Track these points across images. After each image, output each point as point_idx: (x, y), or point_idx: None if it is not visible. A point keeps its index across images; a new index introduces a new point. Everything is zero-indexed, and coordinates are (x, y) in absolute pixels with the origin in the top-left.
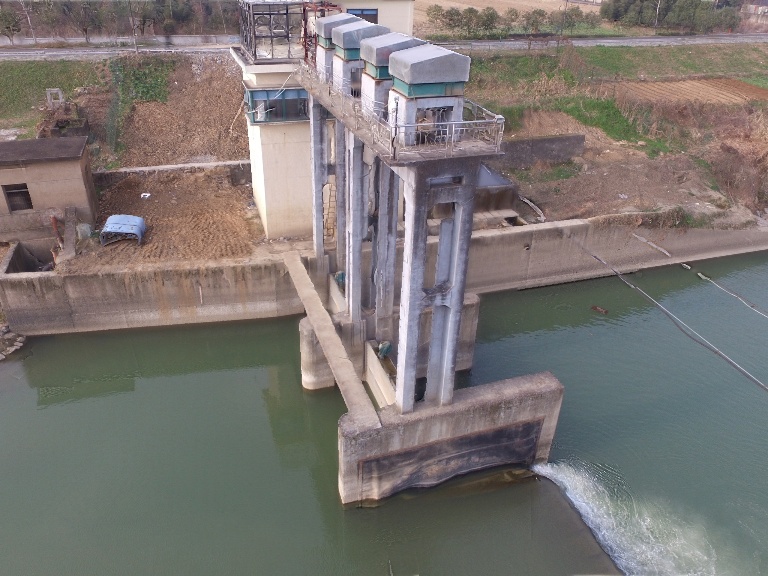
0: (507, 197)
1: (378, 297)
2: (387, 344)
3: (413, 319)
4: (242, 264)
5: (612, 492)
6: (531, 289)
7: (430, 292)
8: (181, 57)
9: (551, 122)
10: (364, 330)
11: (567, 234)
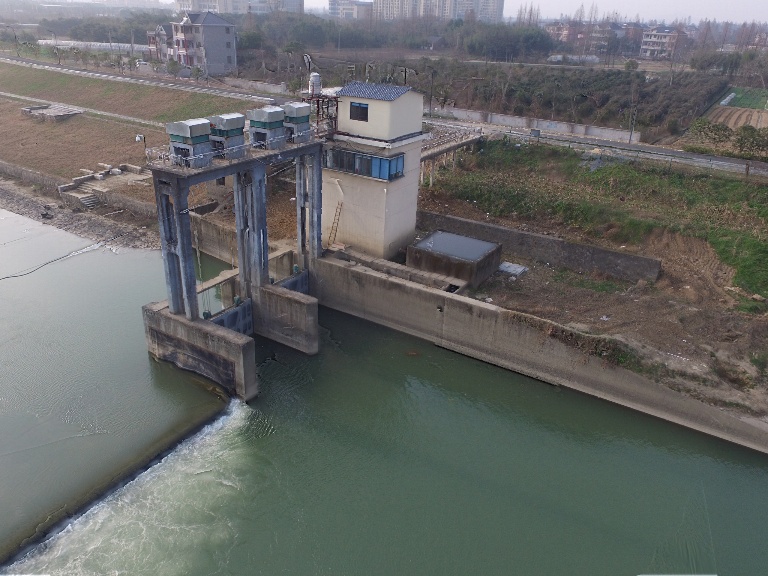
0: (466, 270)
1: (252, 271)
2: (237, 297)
3: (165, 255)
4: None
5: (245, 433)
6: (447, 350)
7: None
8: (426, 127)
9: (682, 247)
10: (246, 289)
11: (477, 313)
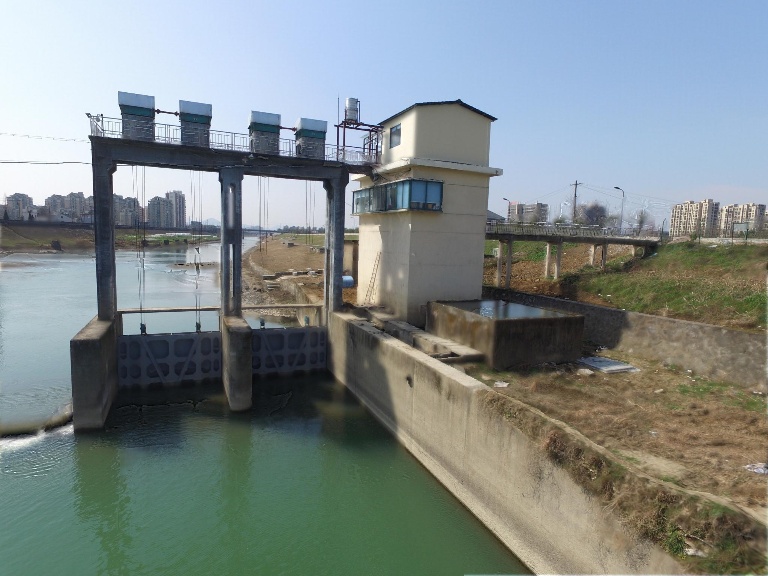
0: (482, 334)
1: None
2: None
3: None
4: None
5: (3, 460)
6: (416, 460)
7: None
8: None
9: None
10: None
11: (446, 391)
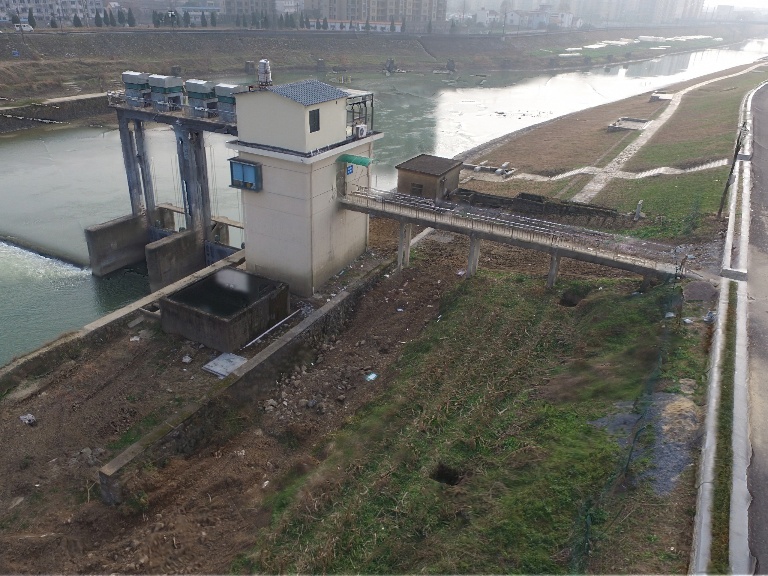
0: None
1: None
2: None
3: None
4: None
5: None
6: None
7: None
8: (705, 235)
9: None
10: None
11: None
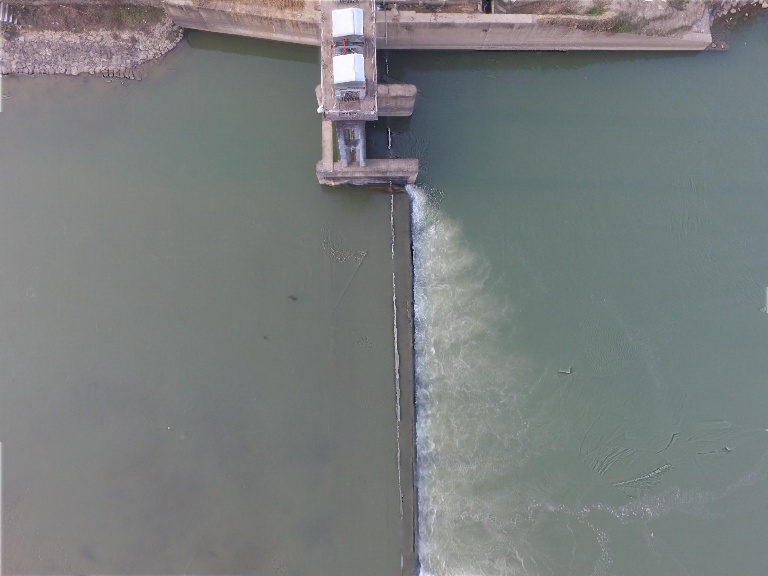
0: None
1: None
2: None
3: None
4: (296, 19)
5: (433, 205)
6: (485, 51)
7: (350, 144)
8: None
9: None
10: None
11: (517, 27)
